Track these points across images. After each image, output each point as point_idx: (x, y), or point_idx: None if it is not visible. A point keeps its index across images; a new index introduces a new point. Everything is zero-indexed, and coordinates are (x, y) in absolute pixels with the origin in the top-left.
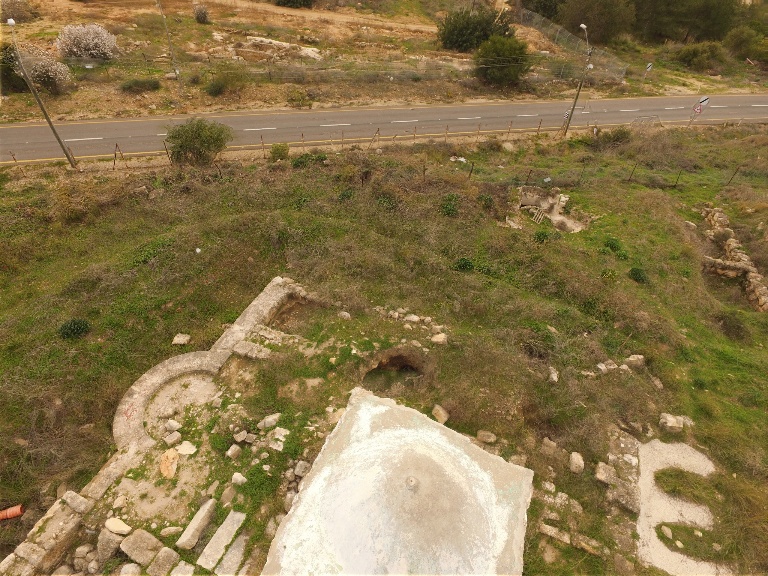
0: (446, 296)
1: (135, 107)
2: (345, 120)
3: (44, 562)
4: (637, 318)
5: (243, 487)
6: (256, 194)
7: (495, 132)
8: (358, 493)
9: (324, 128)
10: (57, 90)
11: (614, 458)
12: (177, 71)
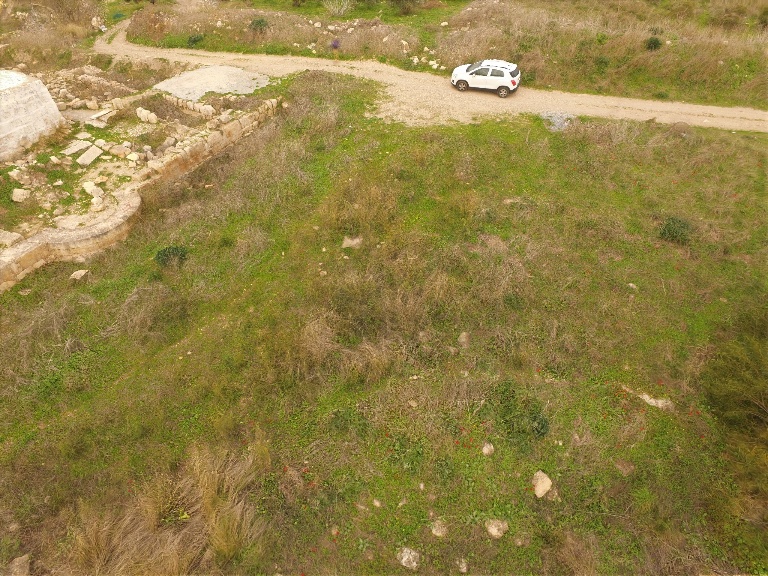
0: None
1: None
2: None
3: None
4: None
5: None
6: None
7: None
8: None
9: None
10: None
11: None
12: None
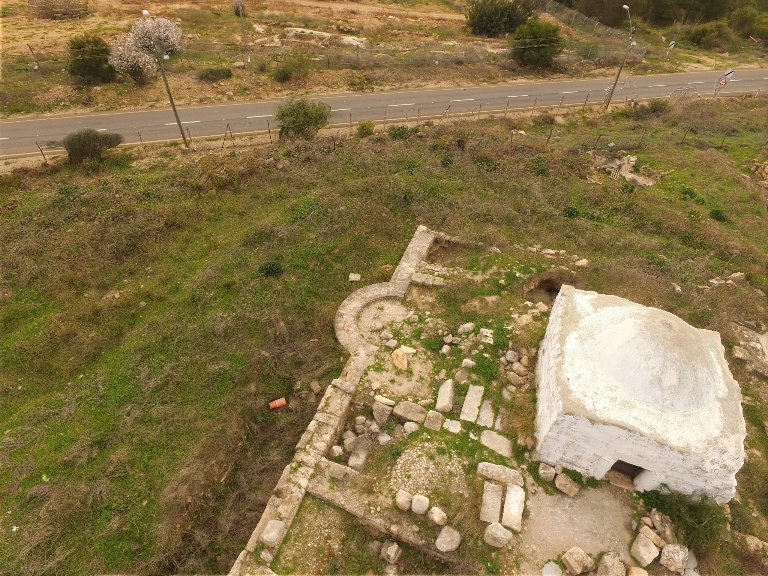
0: (565, 236)
1: (214, 94)
2: (409, 100)
3: (338, 426)
4: (730, 246)
5: (474, 369)
6: None
7: (545, 107)
8: (621, 336)
9: (393, 108)
10: (143, 80)
11: (744, 343)
12: (248, 59)
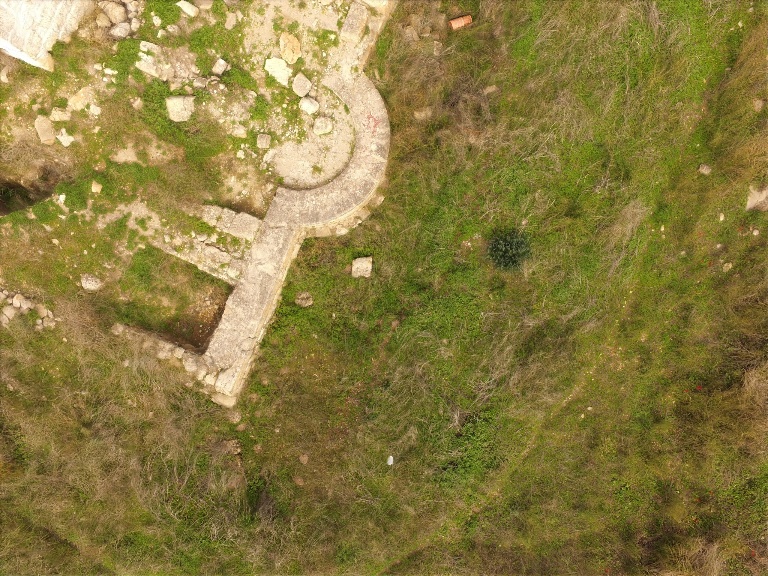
0: None
1: None
2: None
3: None
4: None
5: None
6: None
7: None
8: None
9: None
10: None
11: None
12: None
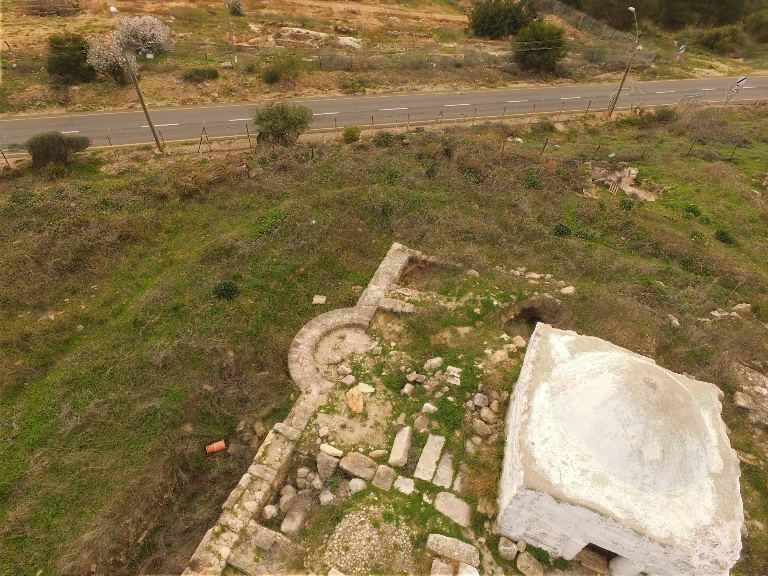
0: (554, 257)
1: (198, 95)
2: (401, 104)
3: (275, 480)
4: (735, 272)
5: (436, 415)
6: (351, 171)
7: (545, 114)
8: (597, 395)
9: (384, 112)
10: (124, 79)
11: (748, 388)
12: (235, 60)
